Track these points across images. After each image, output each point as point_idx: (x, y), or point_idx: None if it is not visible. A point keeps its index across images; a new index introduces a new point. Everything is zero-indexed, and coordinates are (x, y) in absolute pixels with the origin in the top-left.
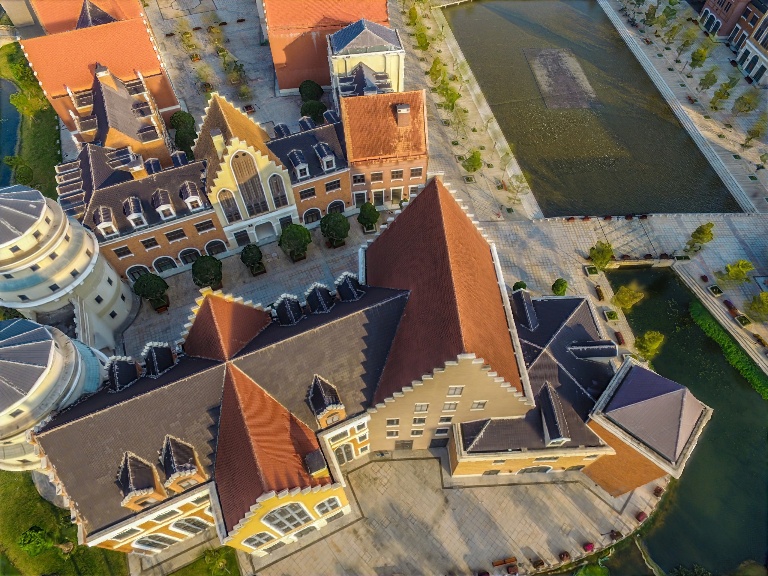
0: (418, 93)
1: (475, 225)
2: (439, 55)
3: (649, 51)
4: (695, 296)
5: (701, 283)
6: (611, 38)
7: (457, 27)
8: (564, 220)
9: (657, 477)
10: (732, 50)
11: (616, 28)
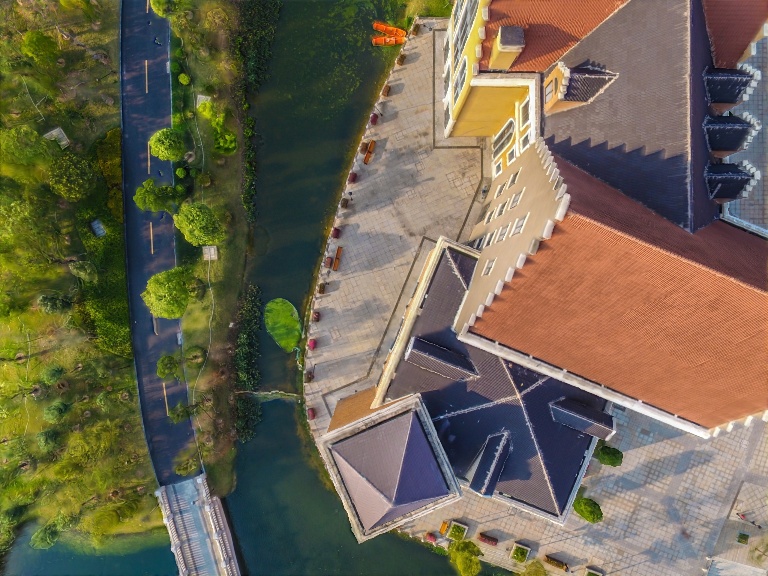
0: None
1: (761, 414)
2: None
3: None
4: None
5: None
6: None
7: None
8: None
9: (329, 429)
10: None
11: None
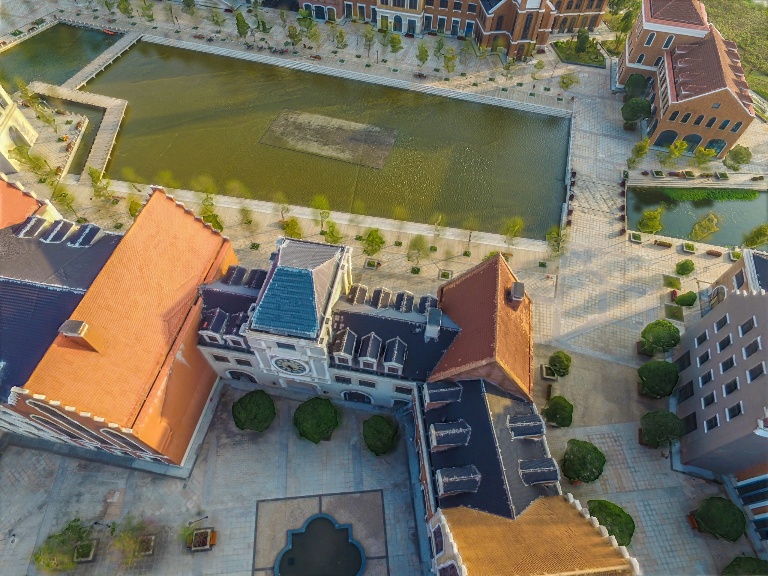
0: (501, 263)
1: None
2: (222, 220)
3: (331, 64)
4: (657, 188)
5: (648, 178)
6: (287, 75)
7: (163, 179)
8: (568, 228)
9: None
10: (362, 23)
11: (273, 64)
